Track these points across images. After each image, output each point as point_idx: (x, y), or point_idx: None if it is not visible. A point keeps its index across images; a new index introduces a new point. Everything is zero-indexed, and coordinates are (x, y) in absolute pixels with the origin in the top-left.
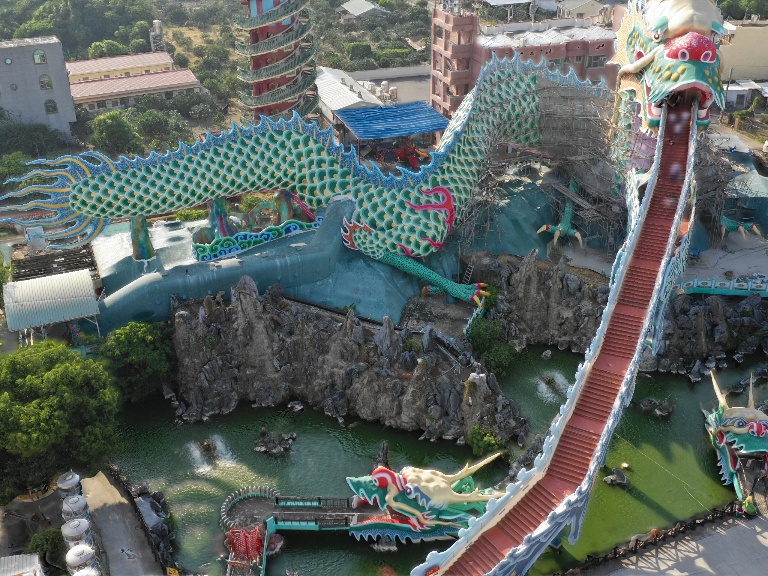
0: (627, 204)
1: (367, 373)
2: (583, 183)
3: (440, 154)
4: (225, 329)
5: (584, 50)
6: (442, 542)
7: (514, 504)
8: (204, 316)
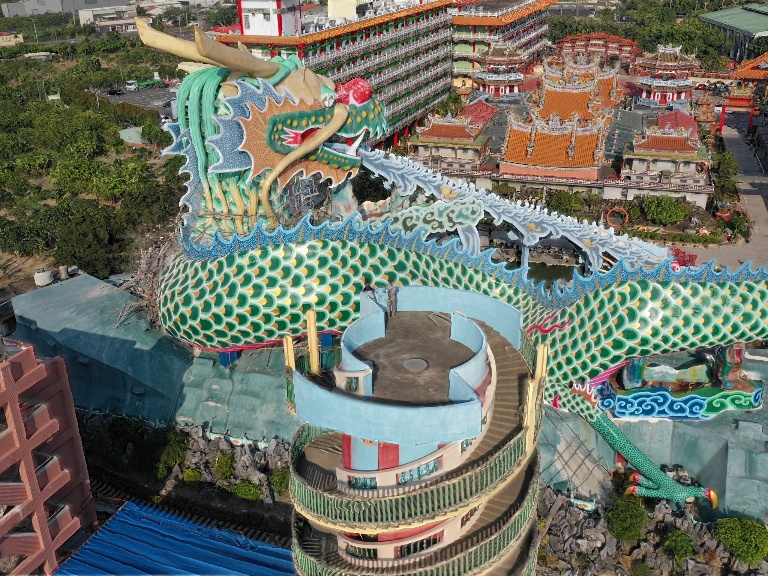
0: None
1: None
2: None
3: (478, 257)
4: None
5: None
6: None
7: None
8: None
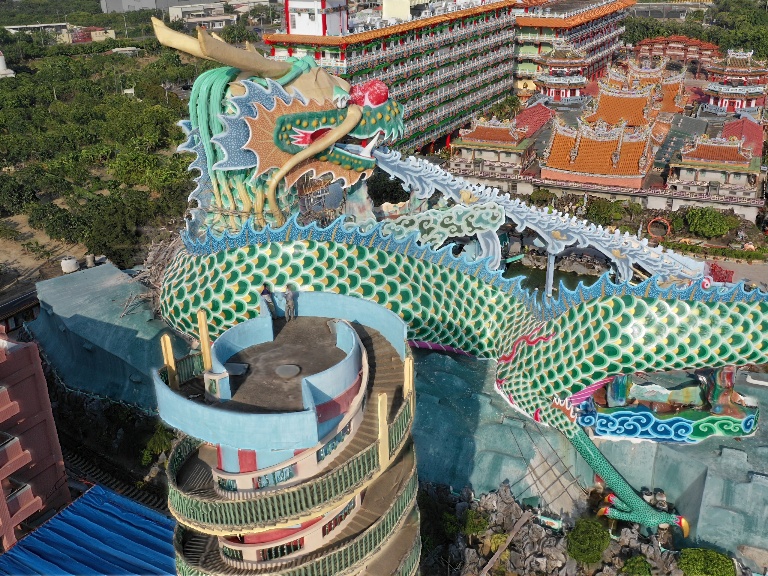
0: None
1: None
2: None
3: (475, 263)
4: None
5: None
6: None
7: None
8: None
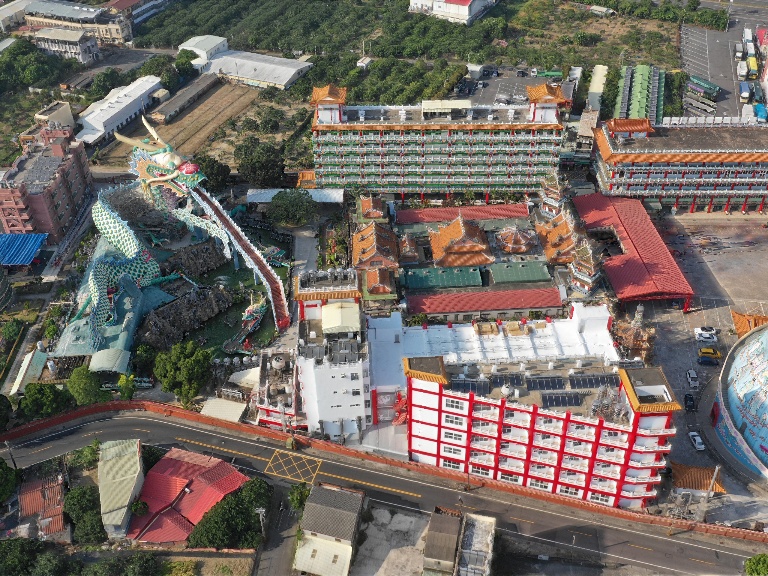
0: (182, 220)
1: (199, 308)
2: (150, 223)
3: None
4: None
5: (63, 172)
6: (262, 319)
7: (272, 295)
8: (155, 328)
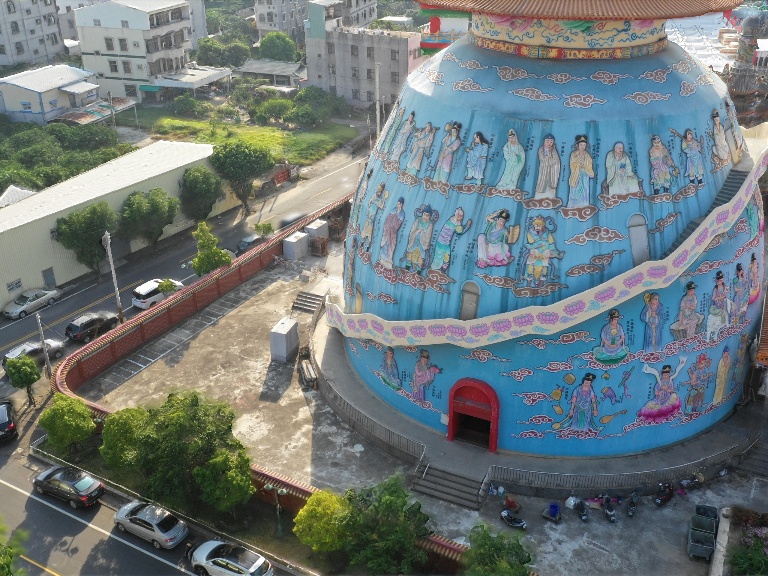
0: None
1: None
2: None
3: None
4: (759, 28)
5: None
6: None
7: None
8: None
